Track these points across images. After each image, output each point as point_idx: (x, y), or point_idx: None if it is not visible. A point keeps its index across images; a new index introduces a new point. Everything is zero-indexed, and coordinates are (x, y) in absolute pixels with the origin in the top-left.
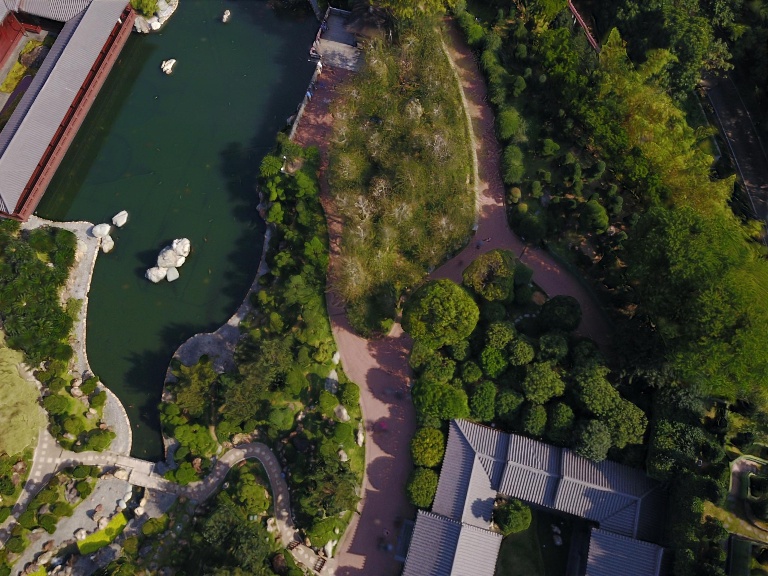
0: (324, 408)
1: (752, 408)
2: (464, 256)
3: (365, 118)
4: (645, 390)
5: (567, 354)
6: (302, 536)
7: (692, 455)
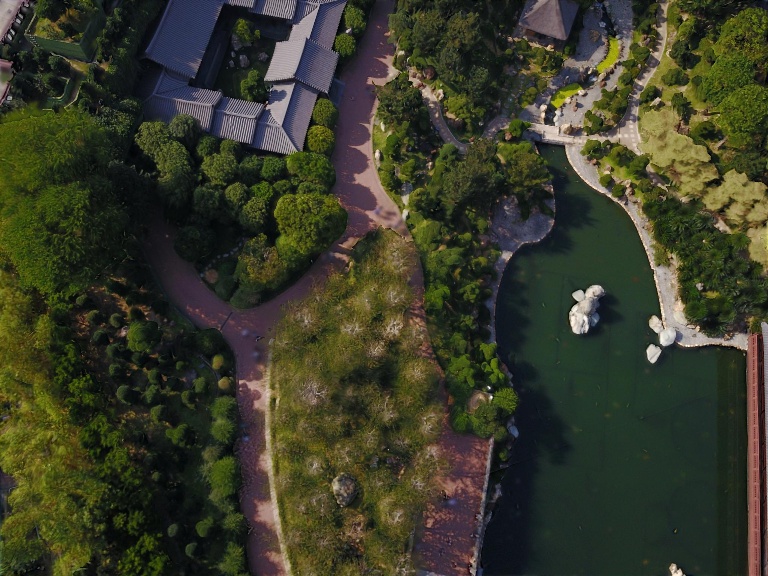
0: None
1: None
2: None
3: None
4: None
5: None
6: None
7: None
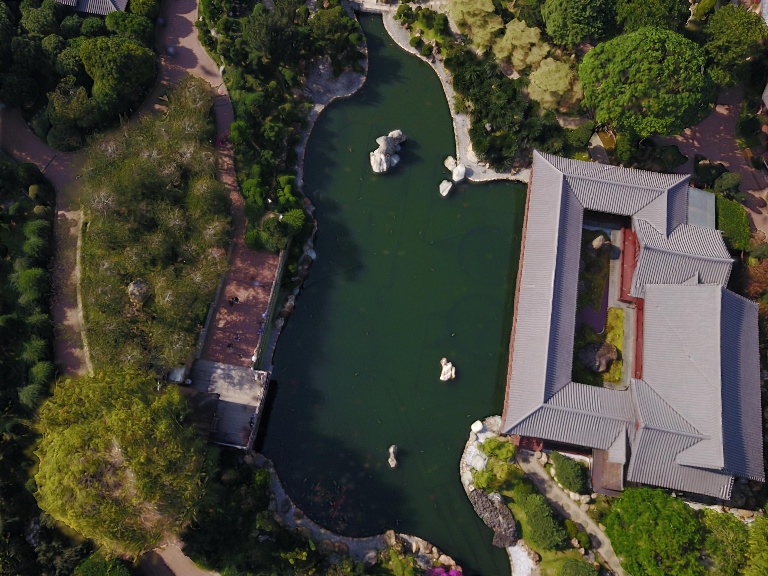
0: None
1: None
2: None
3: None
4: None
5: None
6: None
7: None
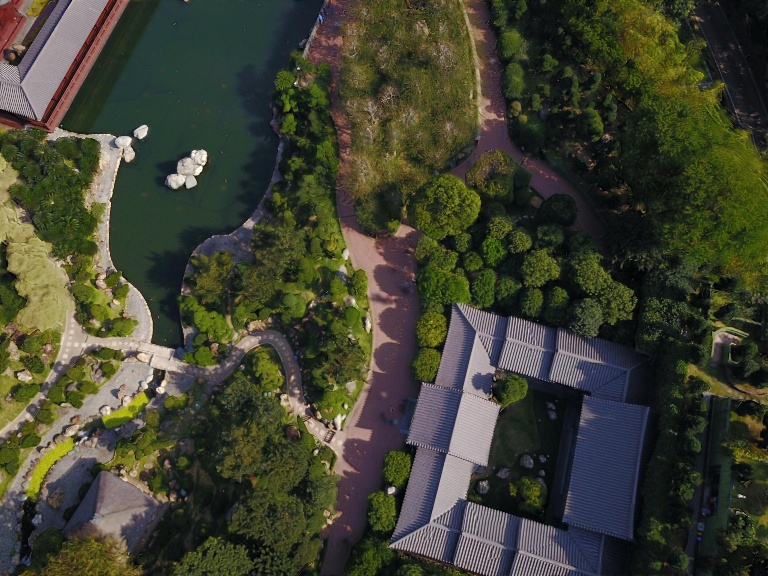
0: (334, 294)
1: (734, 281)
2: (467, 165)
3: (374, 39)
4: (635, 277)
5: (563, 242)
6: (313, 411)
7: (678, 327)
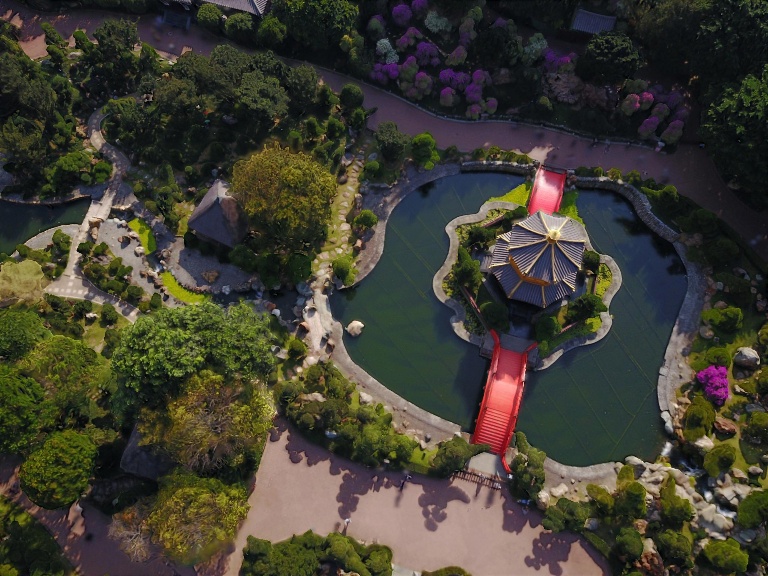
0: (61, 53)
1: None
2: None
3: None
4: None
5: None
6: None
7: None
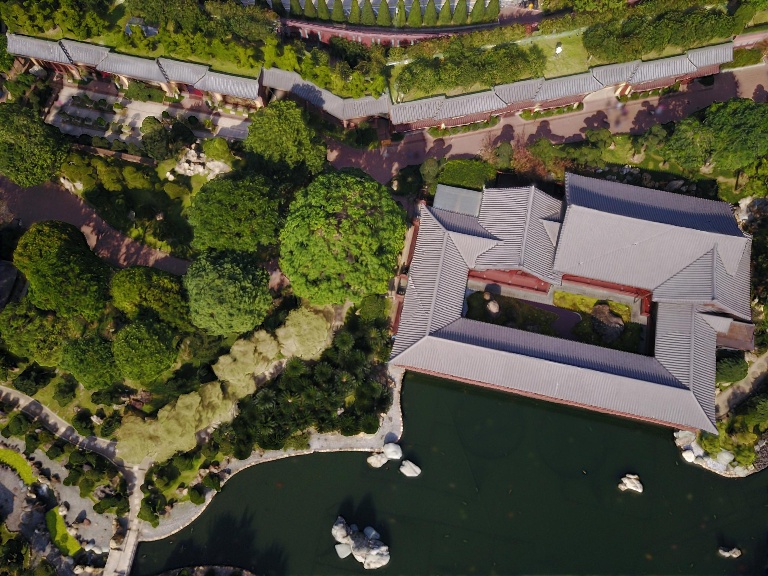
0: None
1: None
2: None
3: None
4: None
5: None
6: None
7: None
